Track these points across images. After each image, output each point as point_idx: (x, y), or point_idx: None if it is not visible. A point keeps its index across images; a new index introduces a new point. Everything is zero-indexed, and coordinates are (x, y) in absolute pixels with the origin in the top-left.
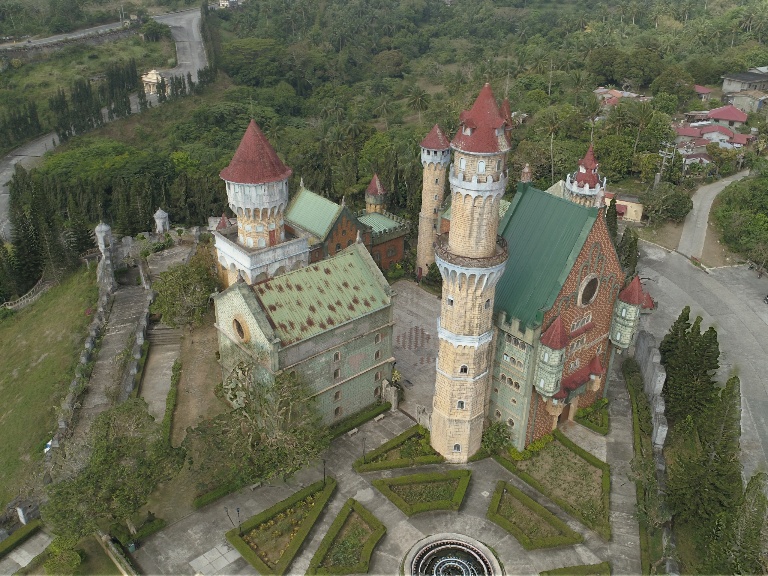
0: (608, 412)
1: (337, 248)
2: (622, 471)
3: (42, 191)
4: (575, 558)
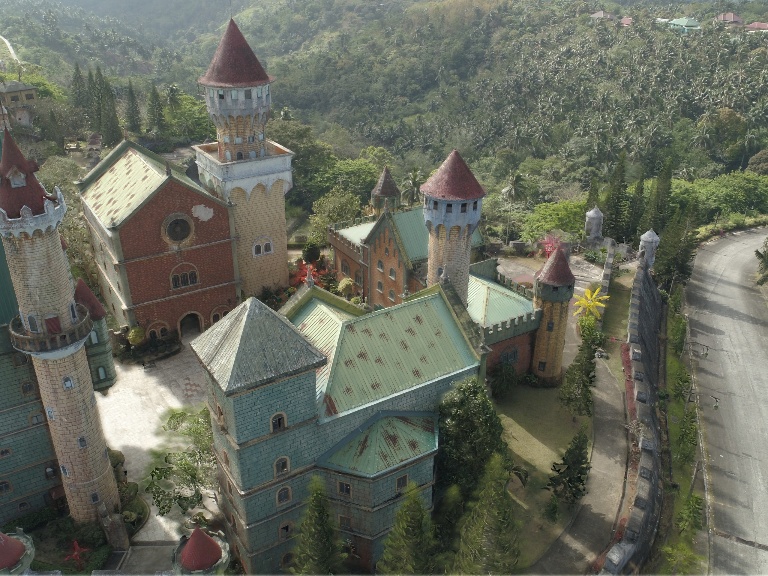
0: None
1: None
2: None
3: (665, 176)
4: None
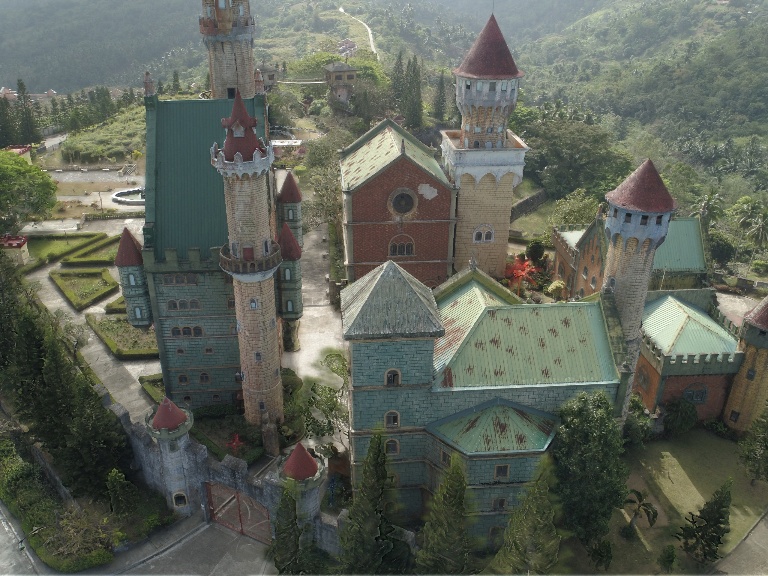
0: None
1: None
2: (106, 367)
3: None
4: (105, 305)
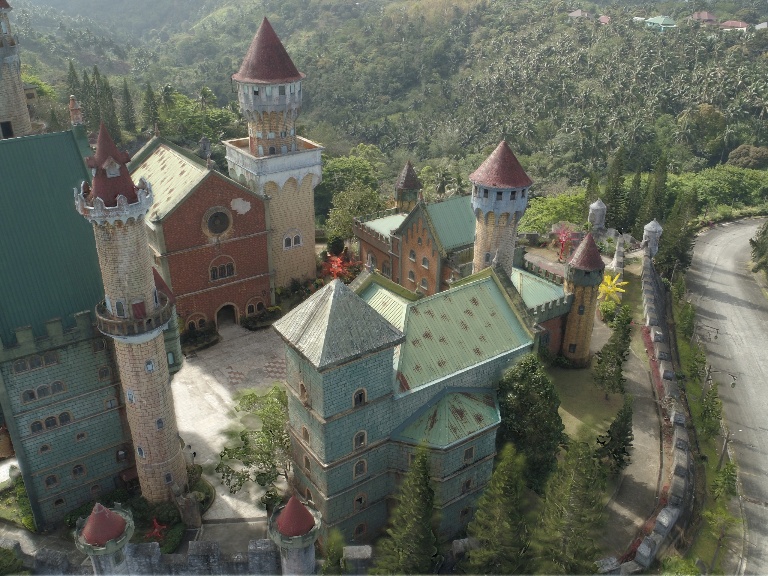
0: (16, 529)
1: (413, 256)
2: None
3: (661, 169)
4: None
